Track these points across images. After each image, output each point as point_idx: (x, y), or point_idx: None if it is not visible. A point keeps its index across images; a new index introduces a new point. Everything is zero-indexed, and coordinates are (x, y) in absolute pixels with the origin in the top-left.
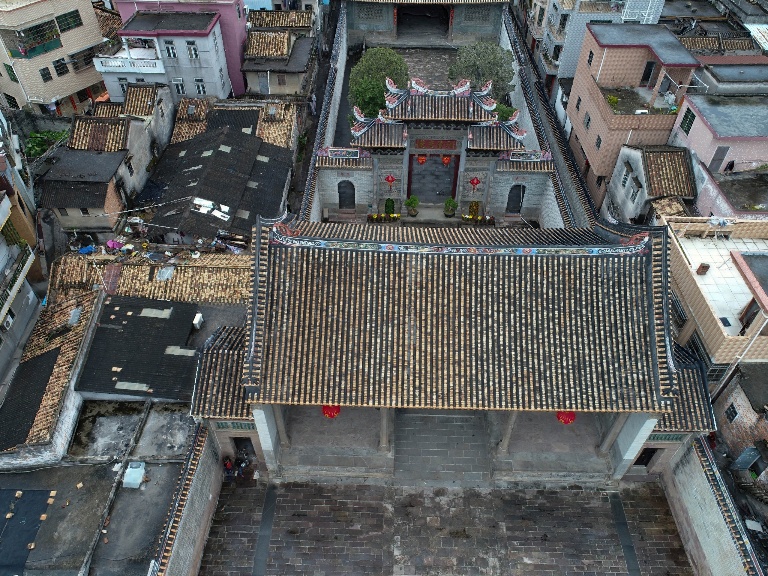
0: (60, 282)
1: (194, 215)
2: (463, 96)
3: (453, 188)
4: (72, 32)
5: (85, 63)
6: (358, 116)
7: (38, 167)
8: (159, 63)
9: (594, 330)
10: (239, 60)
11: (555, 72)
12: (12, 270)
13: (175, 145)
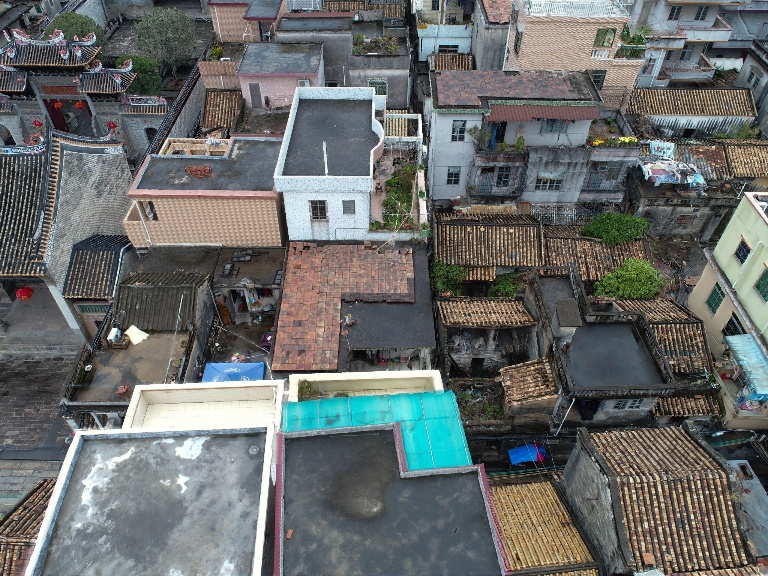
0: None
1: None
2: (62, 45)
3: None
4: None
5: None
6: None
7: None
8: None
9: (3, 214)
10: None
11: None
12: None
13: None
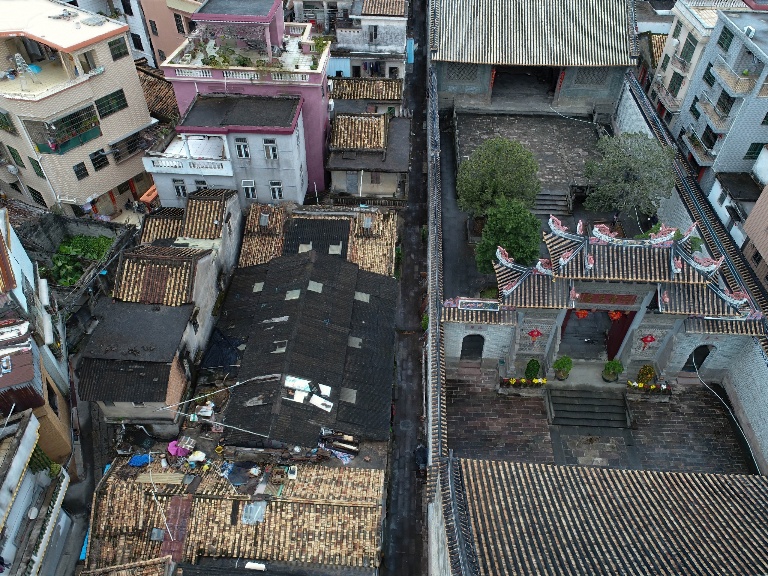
0: (106, 529)
1: (287, 408)
2: (661, 247)
3: (616, 345)
4: (114, 116)
5: (129, 152)
6: (503, 259)
7: (71, 309)
8: (227, 164)
9: None
10: (321, 150)
11: (709, 163)
12: (39, 520)
13: (245, 271)
